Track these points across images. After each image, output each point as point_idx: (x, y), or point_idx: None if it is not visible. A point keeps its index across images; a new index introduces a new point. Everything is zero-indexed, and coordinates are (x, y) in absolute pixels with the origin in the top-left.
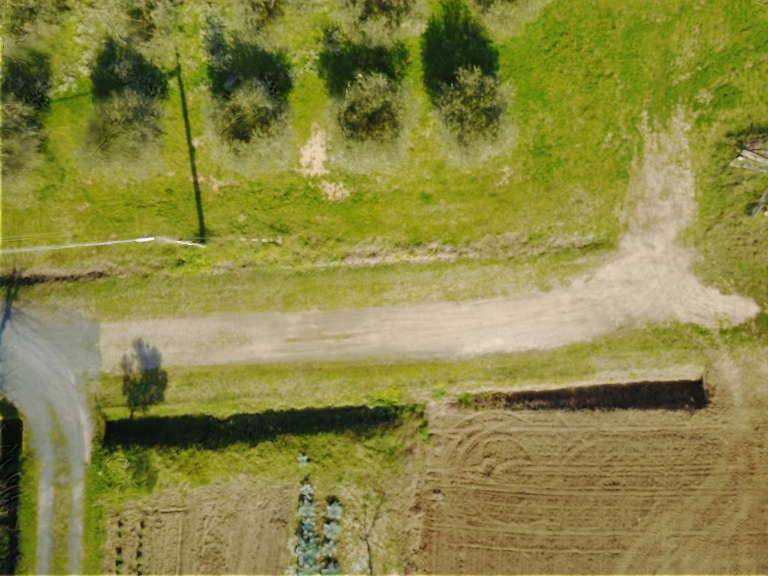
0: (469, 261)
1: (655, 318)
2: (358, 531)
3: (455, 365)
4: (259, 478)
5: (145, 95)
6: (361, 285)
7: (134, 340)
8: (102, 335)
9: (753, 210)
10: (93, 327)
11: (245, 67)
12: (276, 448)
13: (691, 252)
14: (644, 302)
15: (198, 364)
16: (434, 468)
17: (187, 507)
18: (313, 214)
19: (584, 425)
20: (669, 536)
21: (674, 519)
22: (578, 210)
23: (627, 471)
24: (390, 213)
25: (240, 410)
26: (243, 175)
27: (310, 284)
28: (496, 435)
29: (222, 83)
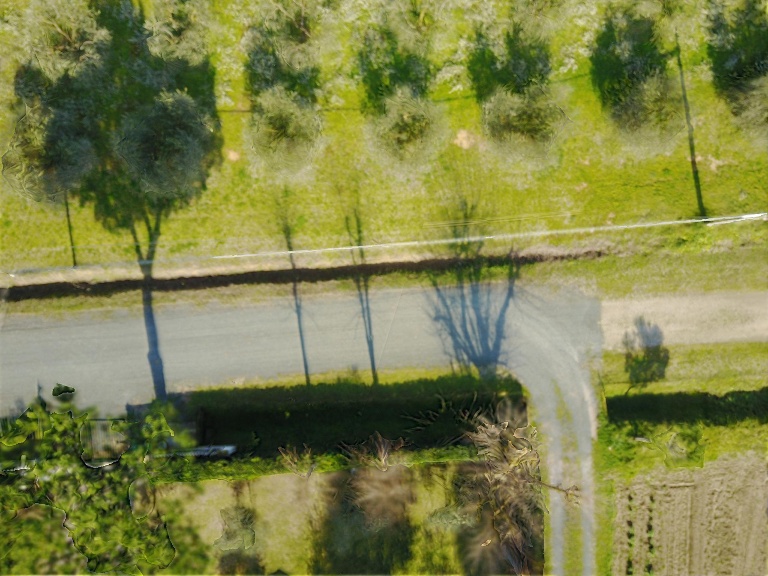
0: None
1: None
2: None
3: None
4: (767, 454)
5: (645, 75)
6: None
7: (635, 318)
8: (604, 313)
9: None
10: (595, 305)
11: (747, 46)
12: None
13: None
14: None
15: (699, 342)
16: None
17: (695, 482)
18: None
19: None
20: None
21: None
22: None
23: None
24: None
25: (737, 387)
26: (743, 154)
27: None
28: None
29: (723, 62)
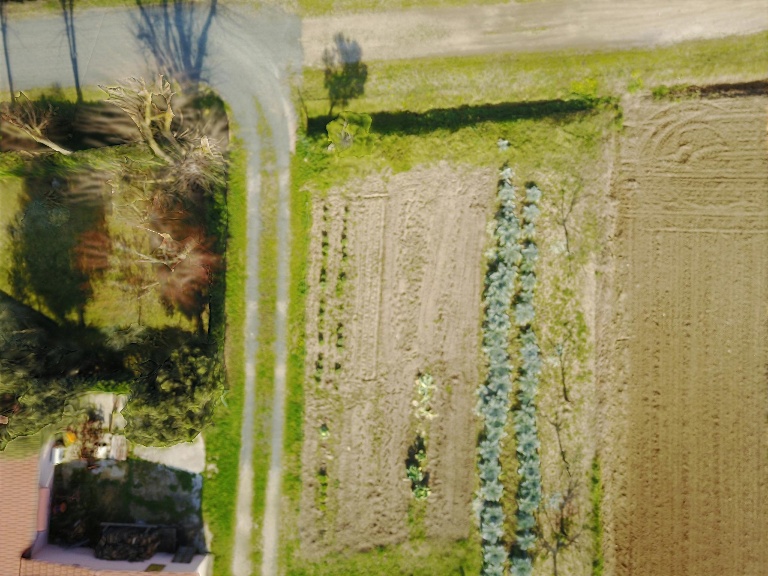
0: None
1: None
2: (556, 216)
3: (653, 53)
4: (459, 164)
5: None
6: None
7: (335, 34)
8: (304, 30)
9: None
10: (295, 22)
11: None
12: (477, 134)
13: None
14: None
15: (397, 57)
16: (628, 159)
17: (389, 193)
18: None
19: None
20: None
21: None
22: None
23: None
24: None
25: (436, 105)
26: None
27: None
28: (692, 124)
29: None
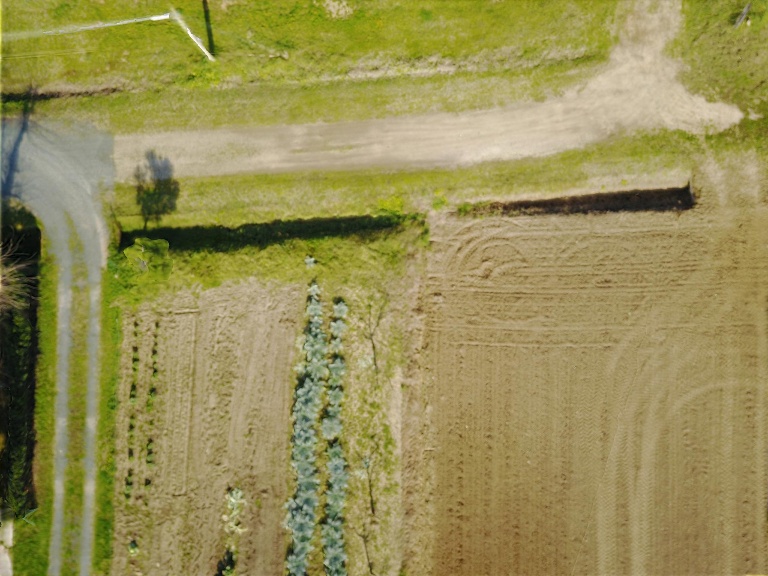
0: (467, 74)
1: (644, 125)
2: (363, 330)
3: (455, 173)
4: (268, 280)
5: None
6: (364, 98)
7: (147, 152)
8: (116, 147)
9: (737, 19)
10: (107, 139)
11: None
12: (284, 251)
13: (678, 62)
14: (634, 110)
15: (209, 174)
16: (435, 273)
17: (200, 308)
18: (318, 31)
19: (577, 228)
20: (658, 329)
21: (663, 312)
22: (571, 24)
23: (618, 269)
24: (392, 29)
25: (249, 220)
26: None
27: (315, 97)
28: (494, 240)
29: None
